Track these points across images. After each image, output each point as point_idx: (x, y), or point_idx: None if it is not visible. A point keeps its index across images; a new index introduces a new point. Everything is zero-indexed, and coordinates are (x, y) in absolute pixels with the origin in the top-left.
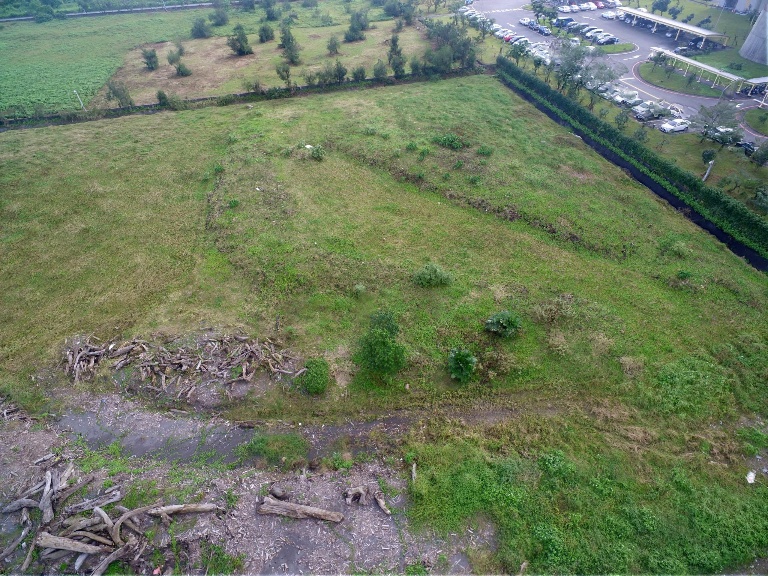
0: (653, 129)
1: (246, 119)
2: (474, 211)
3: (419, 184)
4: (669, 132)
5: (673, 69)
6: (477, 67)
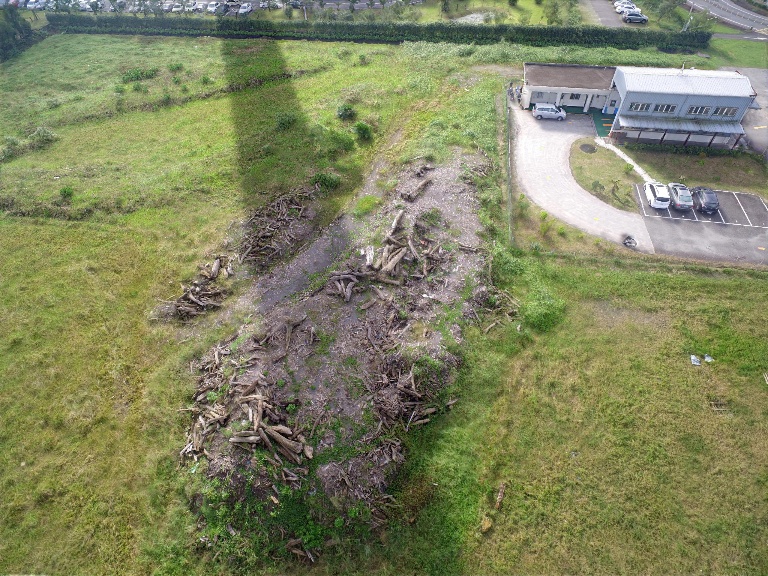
0: None
1: None
2: (235, 94)
3: (173, 103)
4: (247, 14)
5: None
6: (37, 32)
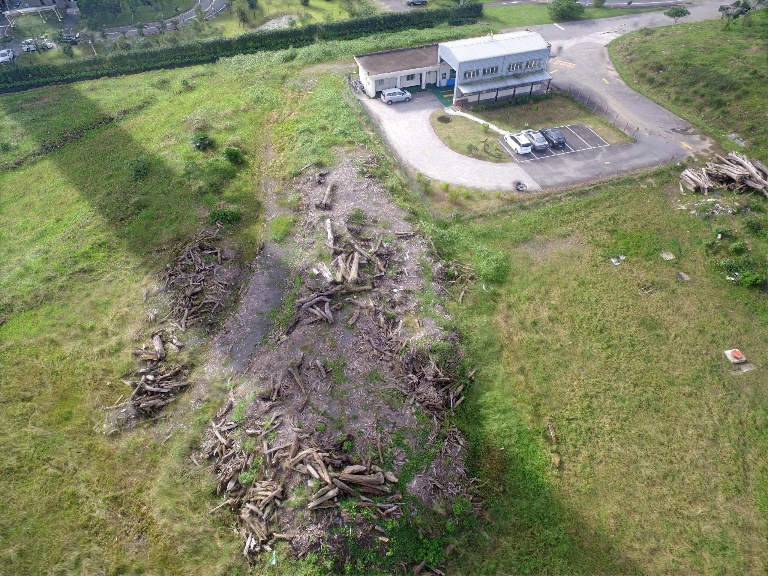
0: None
1: None
2: (53, 154)
3: None
4: None
5: None
6: None
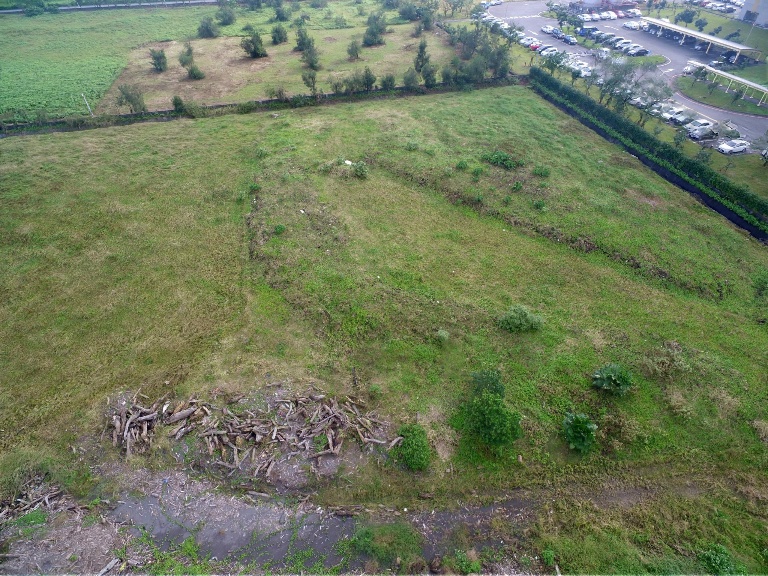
0: (711, 150)
1: (273, 129)
2: (545, 240)
3: (478, 208)
4: (728, 153)
5: (716, 85)
6: (510, 77)
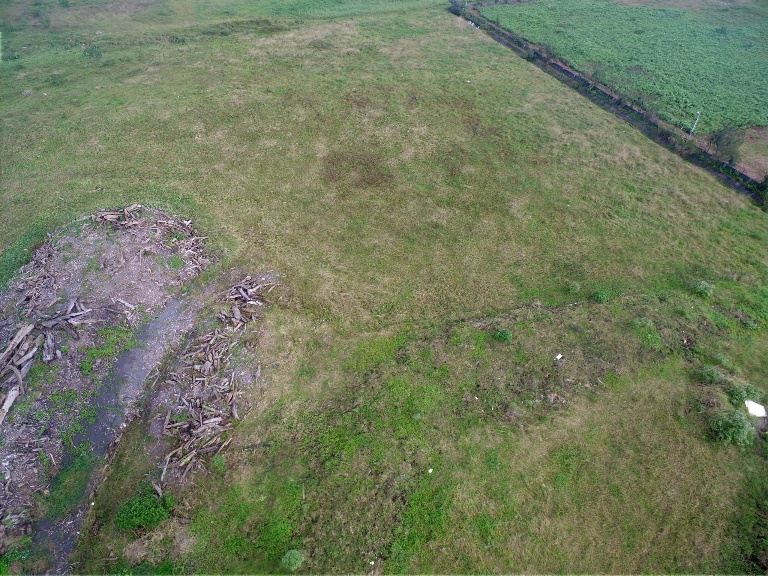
0: None
1: None
2: None
3: None
4: None
5: None
6: None
